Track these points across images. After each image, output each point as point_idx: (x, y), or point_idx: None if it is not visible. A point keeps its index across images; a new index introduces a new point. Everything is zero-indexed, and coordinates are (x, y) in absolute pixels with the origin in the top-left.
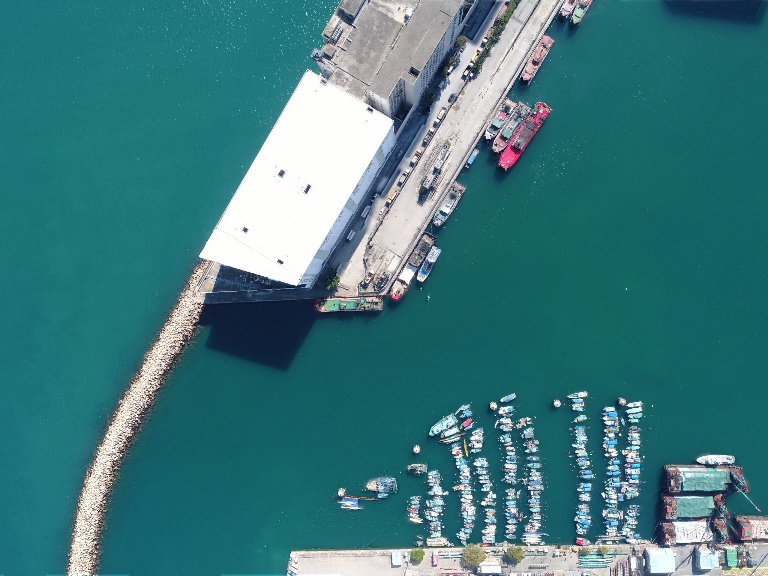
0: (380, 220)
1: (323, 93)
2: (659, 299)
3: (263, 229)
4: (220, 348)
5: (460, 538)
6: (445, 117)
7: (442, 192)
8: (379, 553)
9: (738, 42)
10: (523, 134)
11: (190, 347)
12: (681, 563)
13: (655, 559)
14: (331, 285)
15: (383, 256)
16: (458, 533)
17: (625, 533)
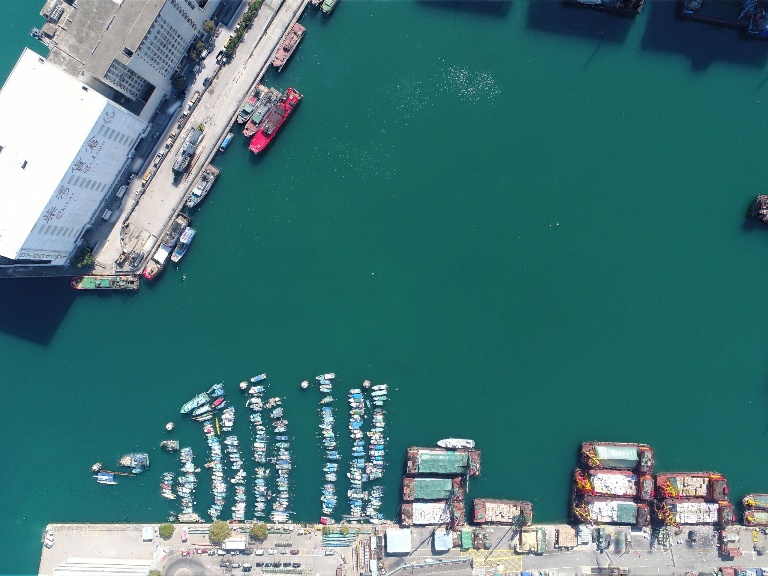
0: (136, 200)
1: (40, 71)
2: (405, 284)
3: None
4: None
5: (211, 514)
6: (200, 101)
7: (196, 174)
8: (132, 527)
9: (484, 34)
10: (272, 119)
11: None
12: (421, 544)
13: (392, 539)
14: (83, 262)
15: (139, 236)
16: (209, 509)
17: (369, 513)
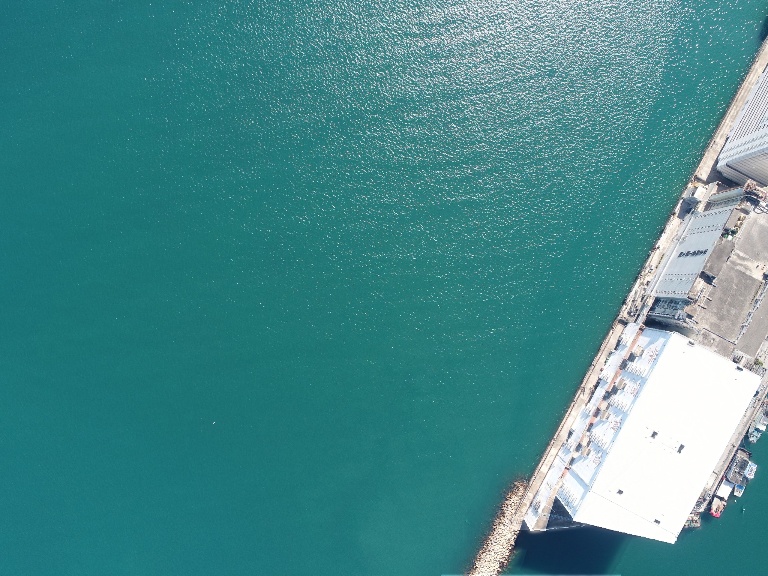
0: None
1: (691, 354)
2: None
3: (637, 490)
4: (536, 572)
5: None
6: None
7: (755, 408)
8: None
9: None
10: None
11: (505, 572)
12: None
13: None
14: None
15: None
16: None
17: None
